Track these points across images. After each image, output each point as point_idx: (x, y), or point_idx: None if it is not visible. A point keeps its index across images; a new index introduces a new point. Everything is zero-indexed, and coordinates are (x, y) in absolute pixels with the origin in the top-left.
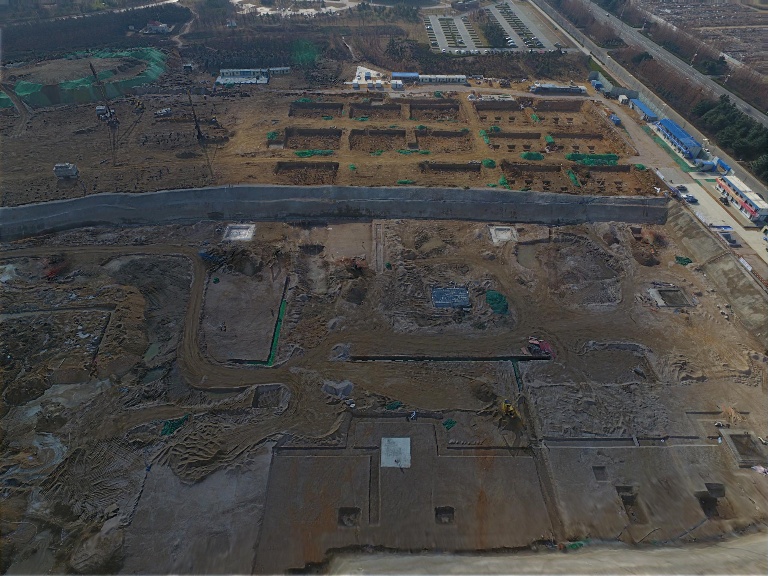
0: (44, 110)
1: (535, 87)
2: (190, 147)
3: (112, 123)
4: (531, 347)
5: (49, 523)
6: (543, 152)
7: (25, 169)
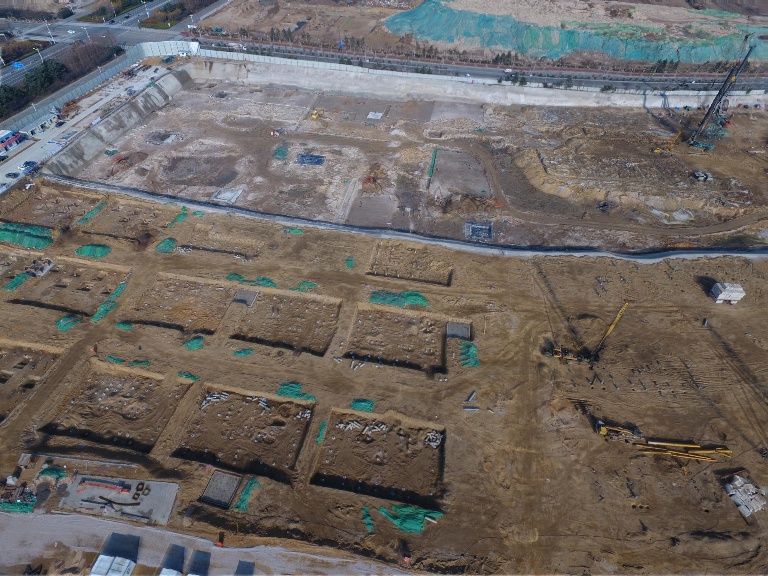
0: None
1: None
2: None
3: None
4: None
5: None
6: None
7: None
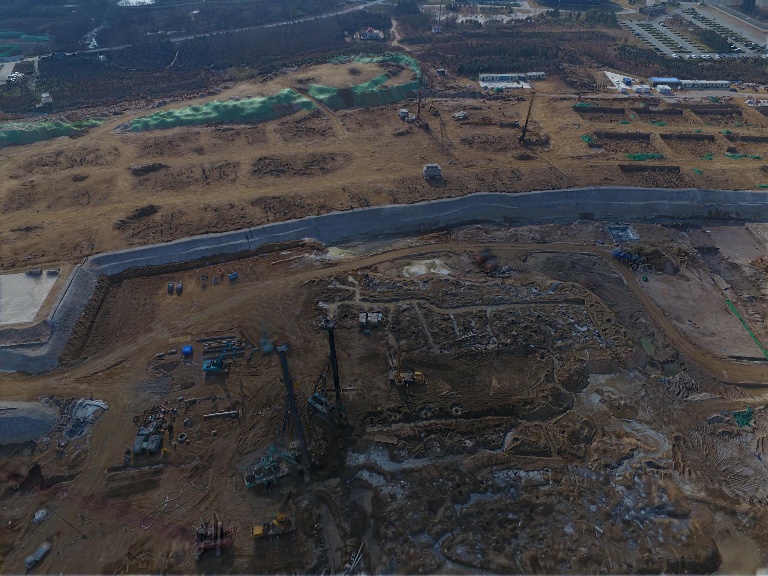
0: (345, 112)
1: None
2: (518, 149)
3: (427, 125)
4: None
5: (717, 505)
6: None
7: (384, 168)
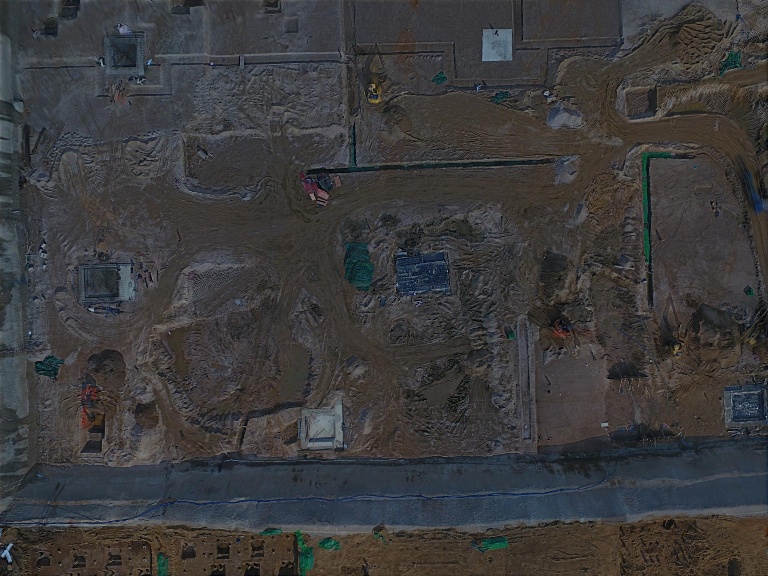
0: None
1: None
2: None
3: None
4: None
5: None
6: None
7: None
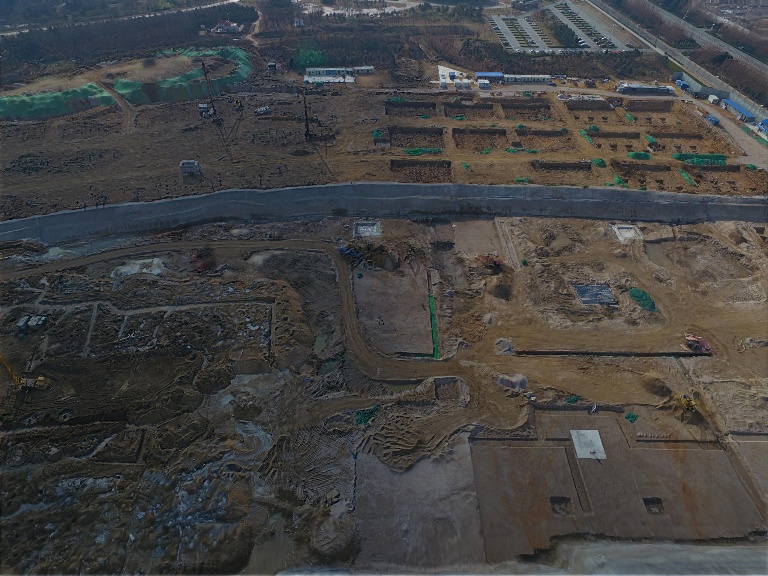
0: (146, 108)
1: (623, 87)
2: (300, 145)
3: (218, 121)
4: (692, 343)
5: (278, 507)
6: (646, 152)
7: (147, 165)
